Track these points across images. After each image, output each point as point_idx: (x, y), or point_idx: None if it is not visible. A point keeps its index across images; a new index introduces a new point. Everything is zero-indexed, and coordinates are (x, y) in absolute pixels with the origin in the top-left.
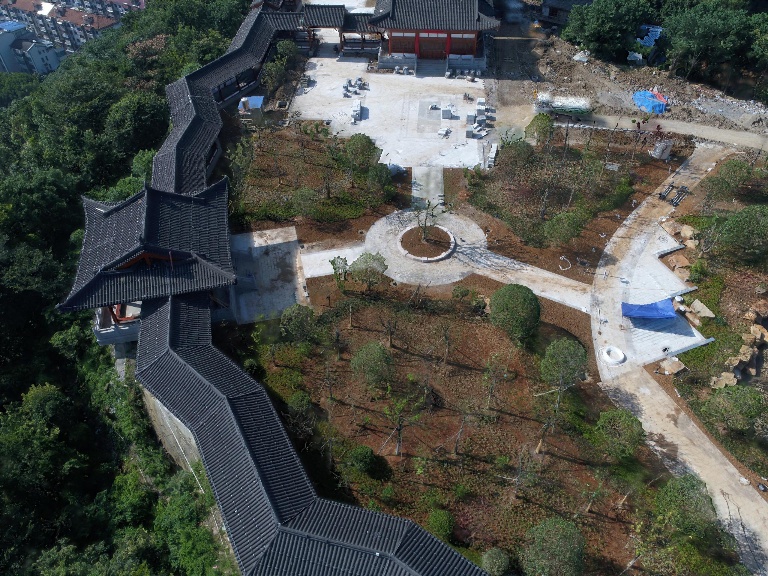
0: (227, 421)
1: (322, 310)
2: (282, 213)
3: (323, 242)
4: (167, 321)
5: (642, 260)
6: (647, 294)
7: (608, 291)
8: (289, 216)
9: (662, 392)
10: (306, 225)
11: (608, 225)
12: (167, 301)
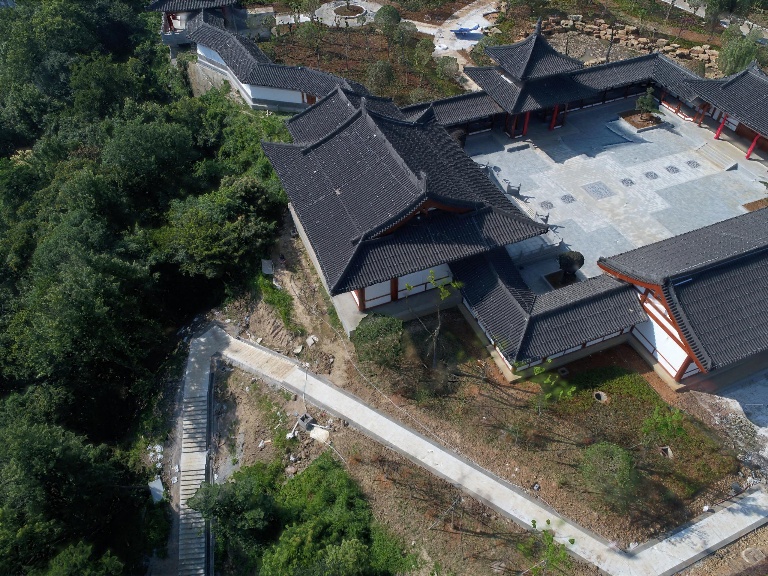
0: (233, 43)
1: (285, 33)
2: (265, 0)
3: (289, 12)
4: (201, 17)
5: (473, 17)
6: (470, 28)
7: (449, 28)
8: (269, 2)
9: (462, 58)
10: (279, 6)
11: (459, 5)
12: (201, 12)
